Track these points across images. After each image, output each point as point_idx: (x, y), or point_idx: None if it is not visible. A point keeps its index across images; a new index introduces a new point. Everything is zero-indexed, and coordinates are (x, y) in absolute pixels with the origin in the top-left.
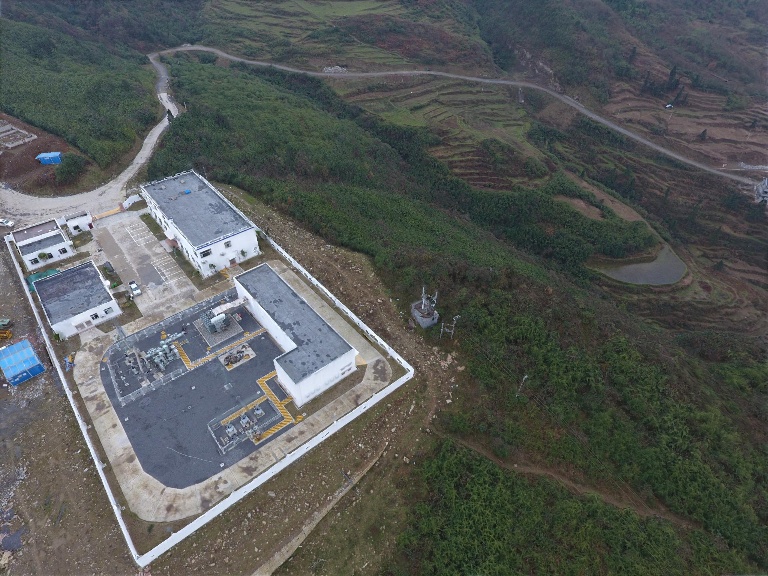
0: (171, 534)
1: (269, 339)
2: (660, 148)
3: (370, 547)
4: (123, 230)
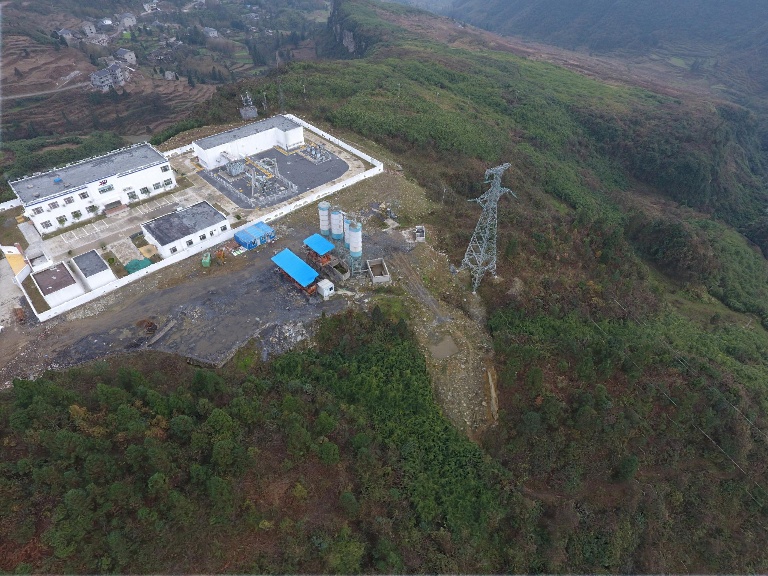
0: (372, 159)
1: (254, 156)
2: (7, 97)
3: (367, 141)
4: (70, 243)
